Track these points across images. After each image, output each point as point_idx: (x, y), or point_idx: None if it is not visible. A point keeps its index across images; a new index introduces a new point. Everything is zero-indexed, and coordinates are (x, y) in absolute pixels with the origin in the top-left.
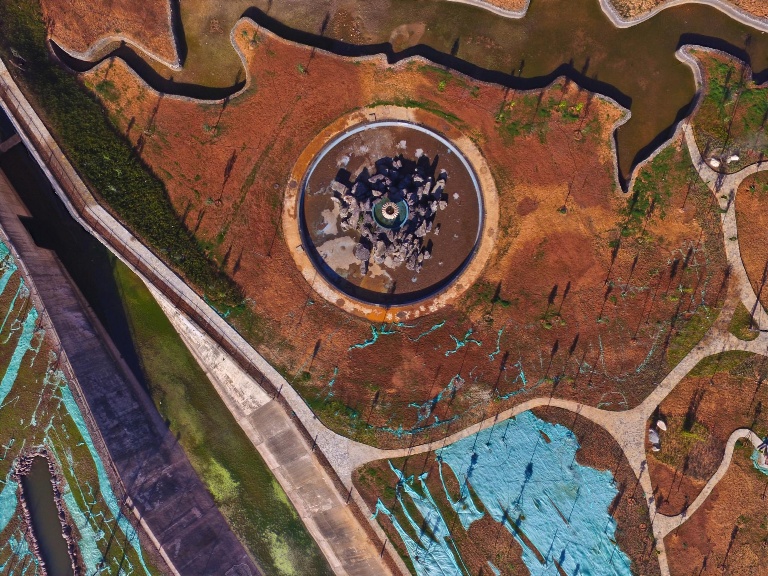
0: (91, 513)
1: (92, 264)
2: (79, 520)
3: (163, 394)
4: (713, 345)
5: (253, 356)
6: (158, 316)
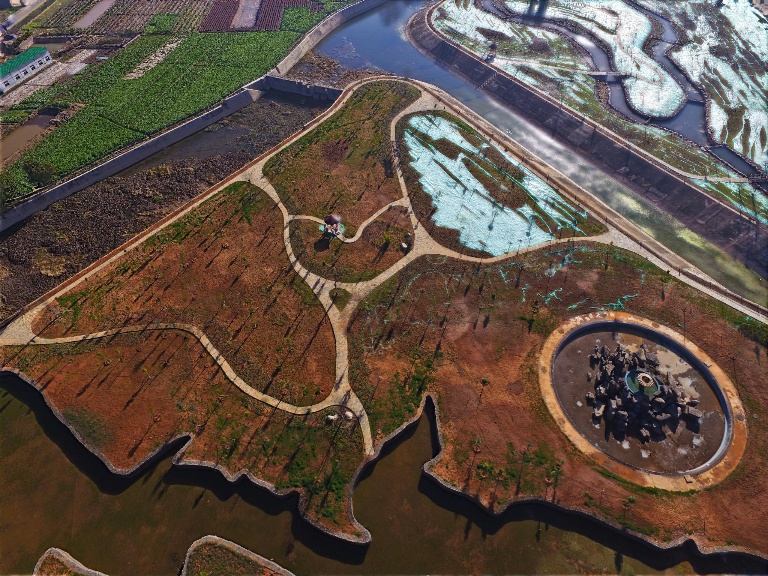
0: None
1: None
2: None
3: (762, 285)
4: (364, 287)
5: (711, 293)
6: None
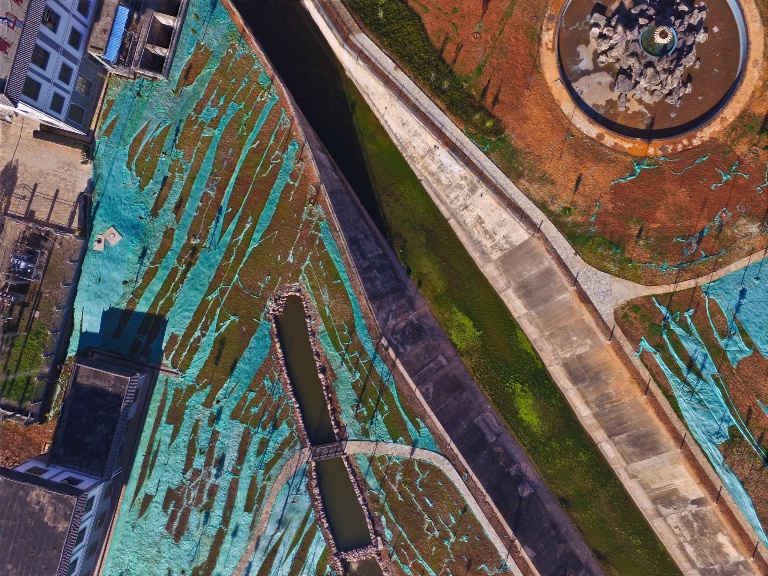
0: (346, 353)
1: (330, 110)
2: (334, 360)
3: (403, 242)
4: None
5: (513, 191)
6: (398, 162)
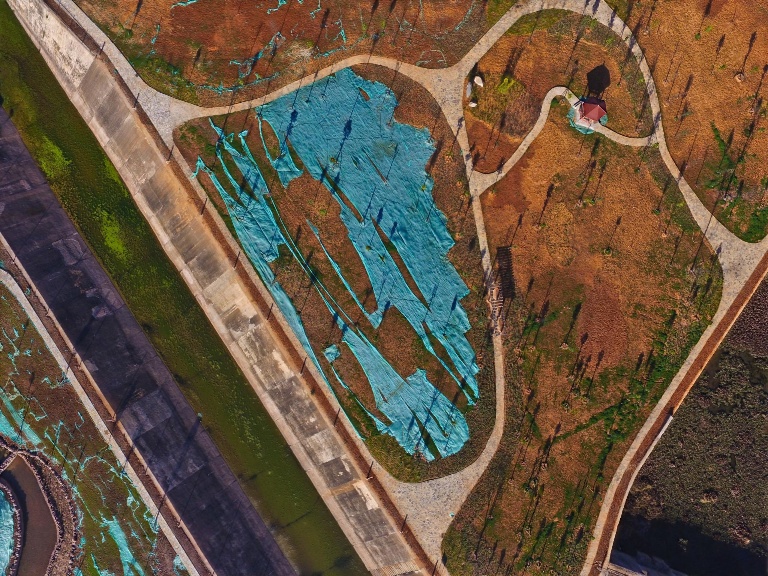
0: None
1: None
2: None
3: None
4: (532, 3)
5: (76, 12)
6: None
